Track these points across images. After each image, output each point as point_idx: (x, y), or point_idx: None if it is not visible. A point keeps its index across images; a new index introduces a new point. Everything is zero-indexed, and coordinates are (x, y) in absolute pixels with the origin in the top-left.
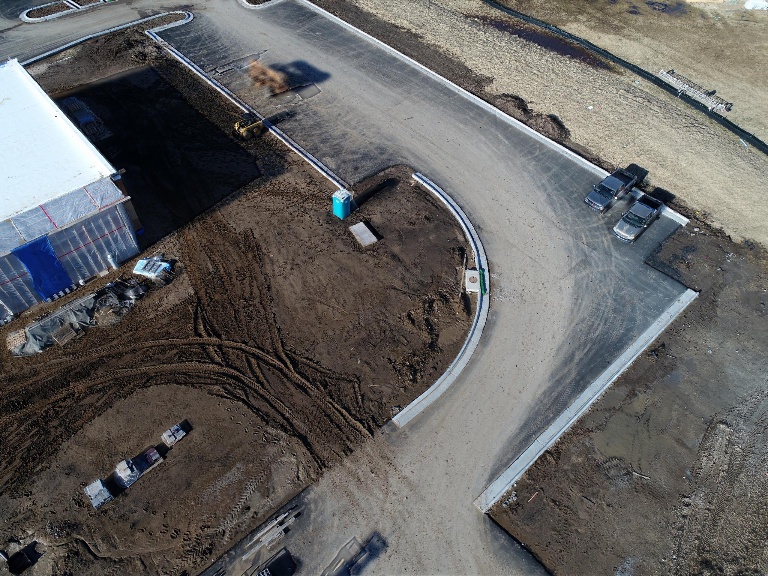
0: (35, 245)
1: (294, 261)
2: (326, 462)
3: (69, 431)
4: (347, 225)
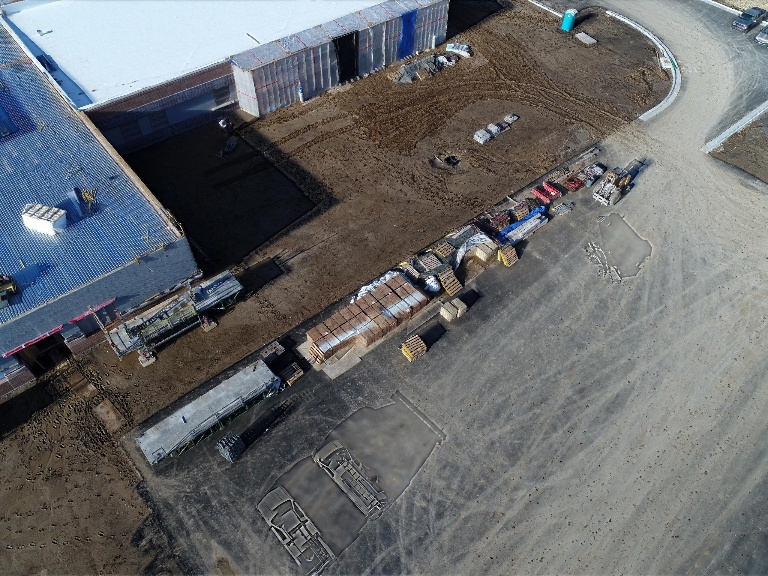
0: (411, 14)
1: (546, 50)
2: (606, 133)
3: (447, 115)
4: (573, 34)
